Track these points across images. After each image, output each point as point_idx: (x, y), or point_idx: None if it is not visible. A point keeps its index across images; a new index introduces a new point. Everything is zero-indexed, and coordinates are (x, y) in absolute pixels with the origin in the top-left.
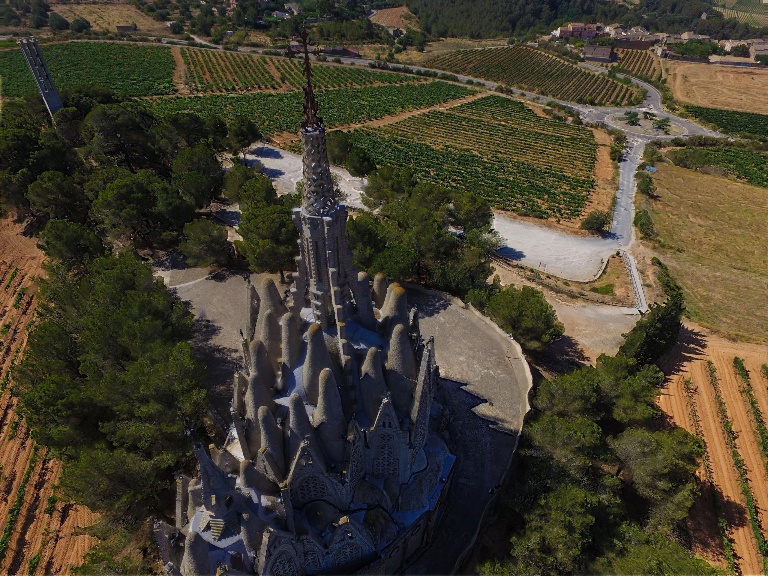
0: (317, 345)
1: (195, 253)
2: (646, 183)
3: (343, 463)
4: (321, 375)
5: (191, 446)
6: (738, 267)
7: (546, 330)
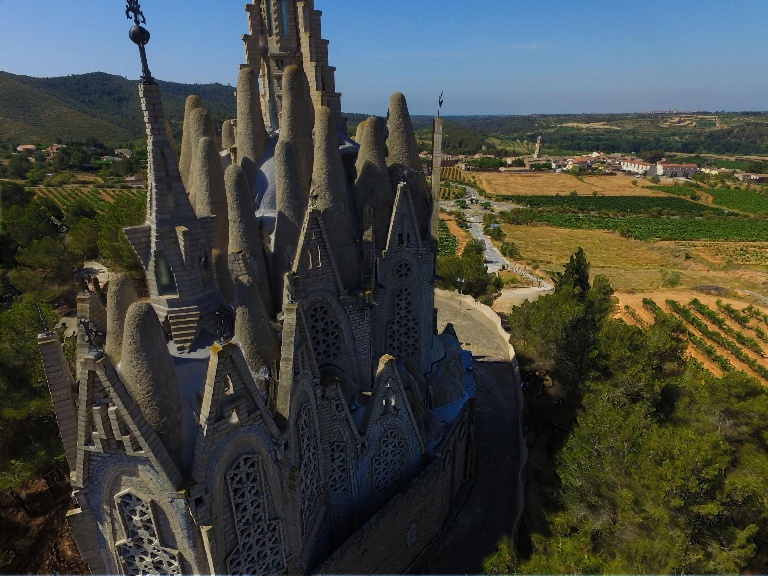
0: (298, 98)
1: (35, 282)
2: (497, 231)
3: (360, 288)
4: (319, 110)
5: (62, 448)
6: (597, 266)
7: (488, 282)
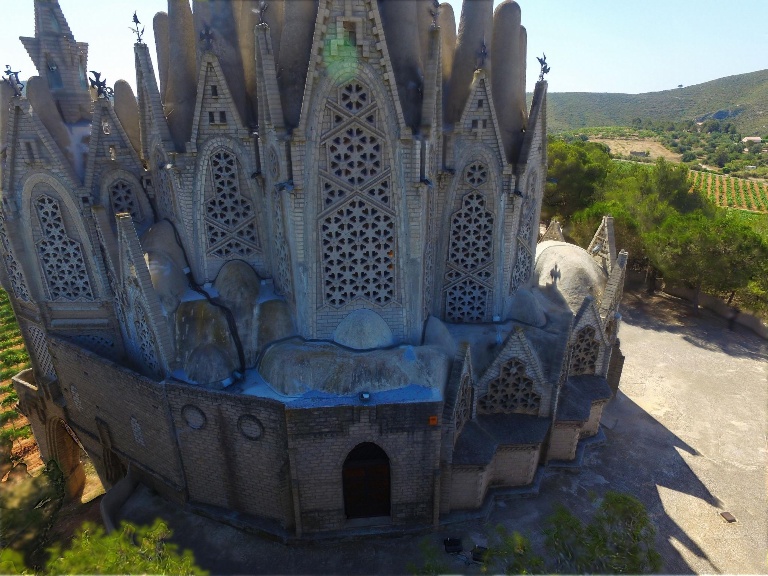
0: None
1: None
2: None
3: None
4: None
5: None
6: None
7: None
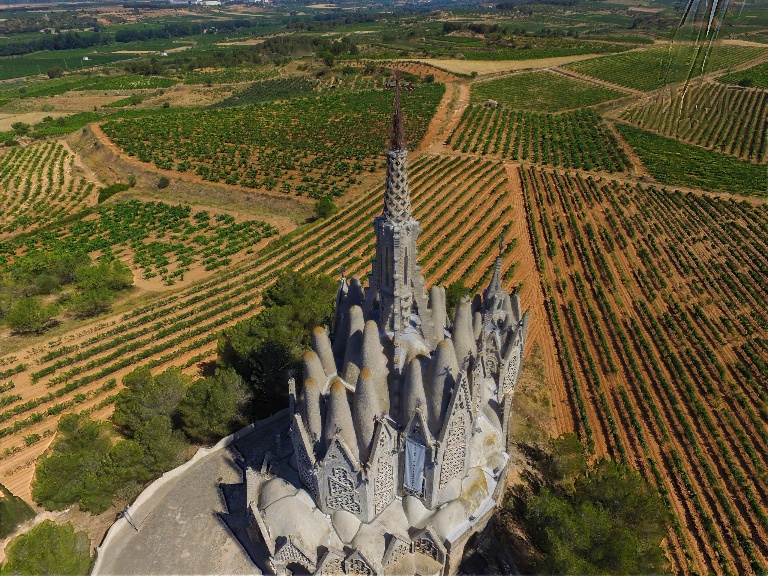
0: None
1: None
2: None
3: None
4: None
5: None
6: None
7: None
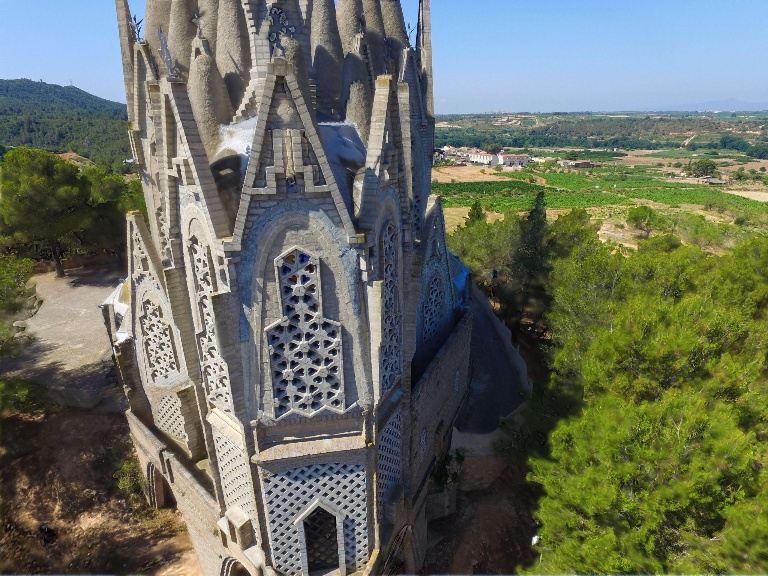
0: None
1: None
2: None
3: None
4: None
5: None
6: None
7: None
